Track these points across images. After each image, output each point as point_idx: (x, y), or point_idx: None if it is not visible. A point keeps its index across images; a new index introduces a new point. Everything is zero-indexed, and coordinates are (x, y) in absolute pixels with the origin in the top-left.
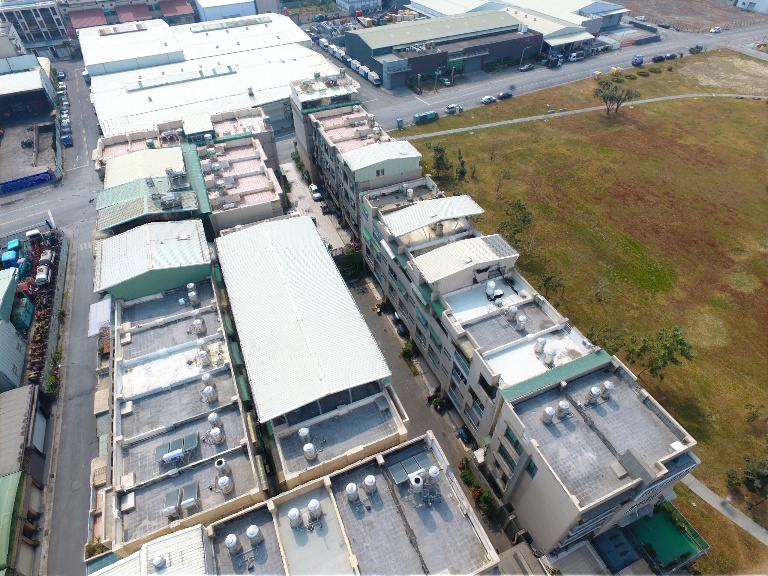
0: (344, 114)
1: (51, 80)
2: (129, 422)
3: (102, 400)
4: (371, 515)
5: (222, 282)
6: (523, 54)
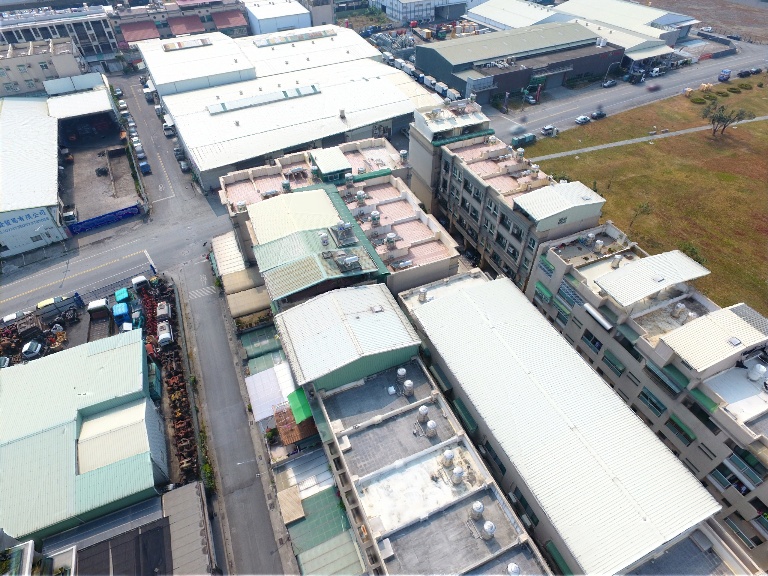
0: (476, 145)
1: None
2: (395, 570)
3: (289, 504)
4: None
5: None
6: (608, 70)
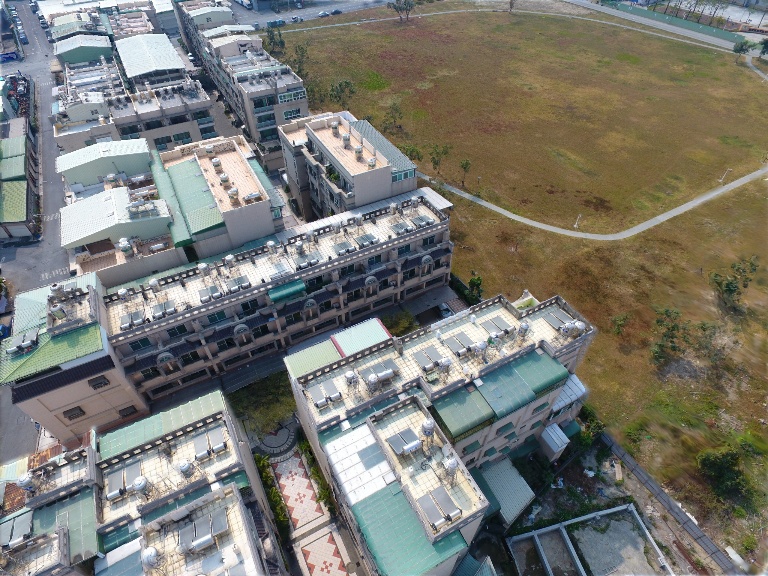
0: None
1: (6, 9)
2: None
3: None
4: (170, 100)
5: (120, 62)
6: None
